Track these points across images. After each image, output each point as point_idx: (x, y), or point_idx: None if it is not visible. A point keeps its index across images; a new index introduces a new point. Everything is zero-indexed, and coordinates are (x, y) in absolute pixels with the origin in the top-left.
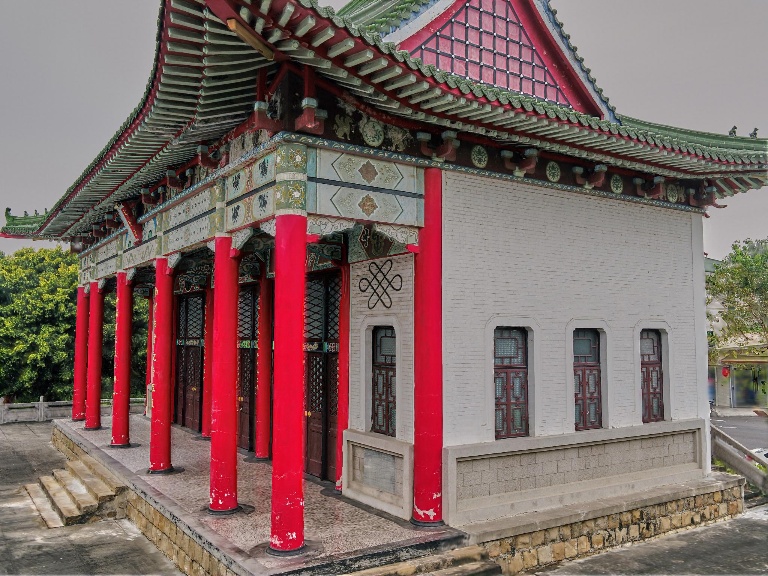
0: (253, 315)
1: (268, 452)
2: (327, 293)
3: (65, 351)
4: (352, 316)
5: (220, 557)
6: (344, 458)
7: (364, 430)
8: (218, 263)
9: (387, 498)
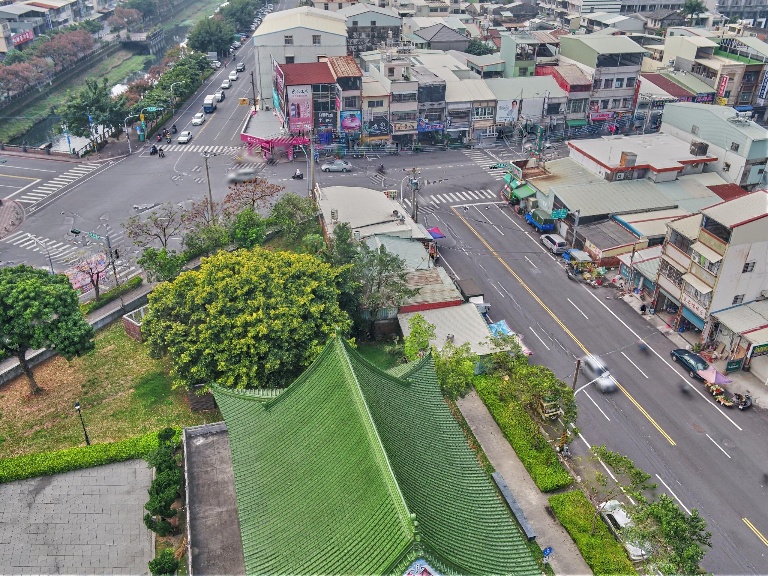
0: None
1: None
2: None
3: (257, 371)
4: None
5: None
6: None
7: None
8: None
9: None
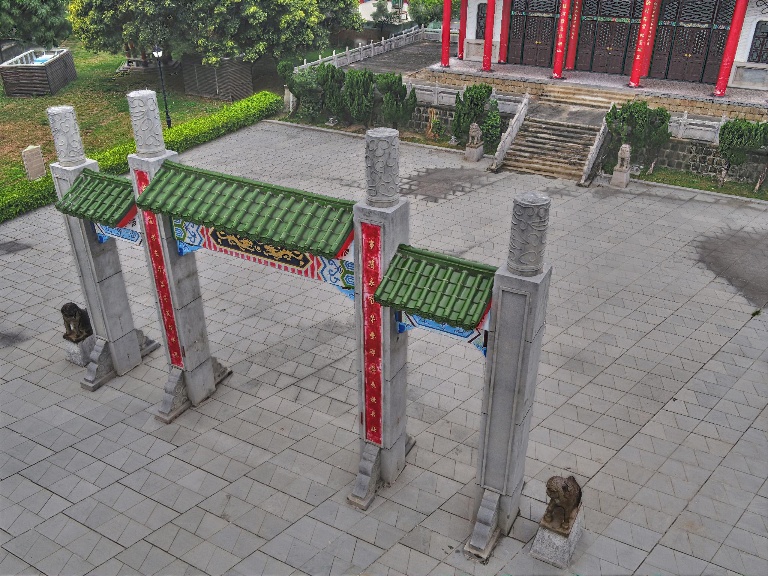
0: (634, 5)
1: (648, 74)
2: (720, 2)
3: None
4: (747, 15)
5: (763, 107)
6: (733, 73)
7: (746, 61)
8: (743, 1)
9: (760, 85)
